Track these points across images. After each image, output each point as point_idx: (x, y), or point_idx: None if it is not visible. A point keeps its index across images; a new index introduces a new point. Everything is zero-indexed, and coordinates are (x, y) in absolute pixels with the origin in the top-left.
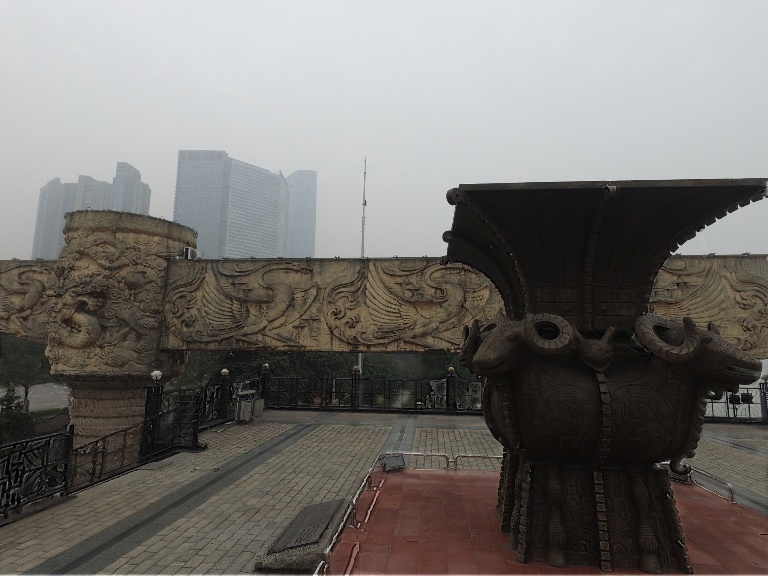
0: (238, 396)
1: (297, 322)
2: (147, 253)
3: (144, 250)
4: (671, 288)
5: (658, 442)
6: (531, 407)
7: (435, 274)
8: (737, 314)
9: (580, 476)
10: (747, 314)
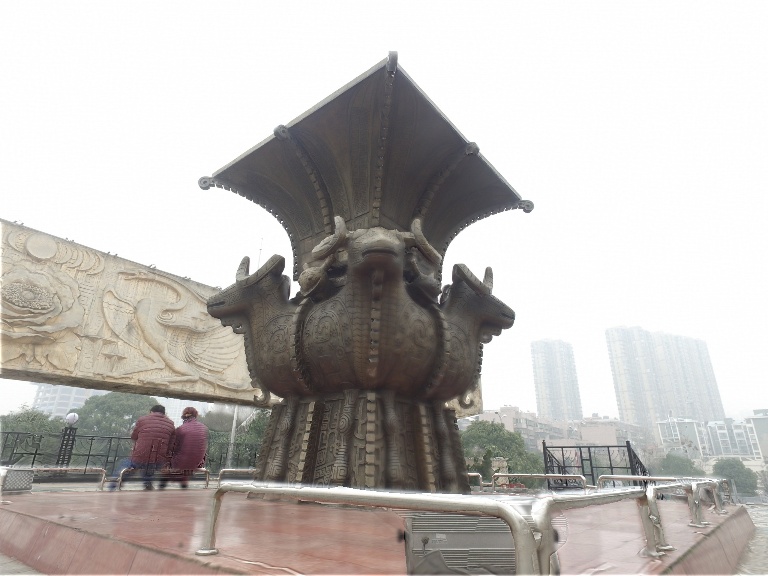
0: None
1: None
2: None
3: None
4: None
5: None
6: None
7: None
8: None
9: None
10: None
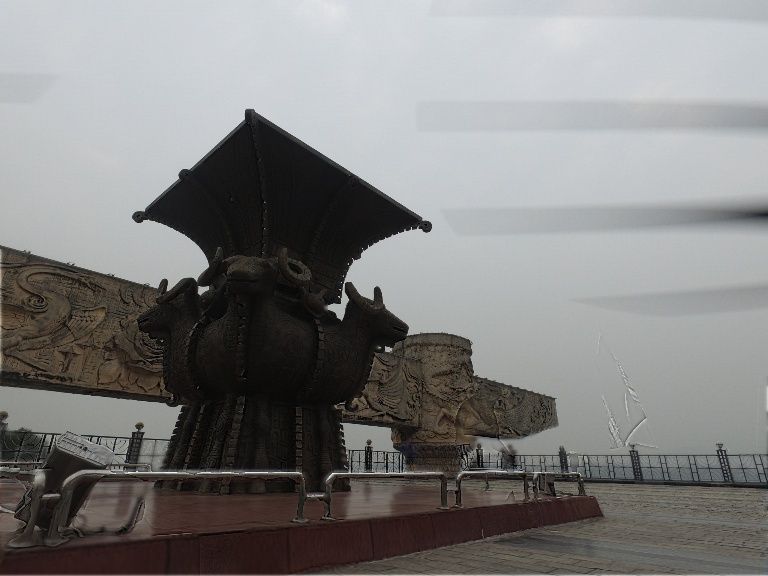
0: None
1: None
2: None
3: None
4: None
5: (346, 381)
6: (265, 334)
7: (36, 277)
8: None
9: (283, 412)
10: None
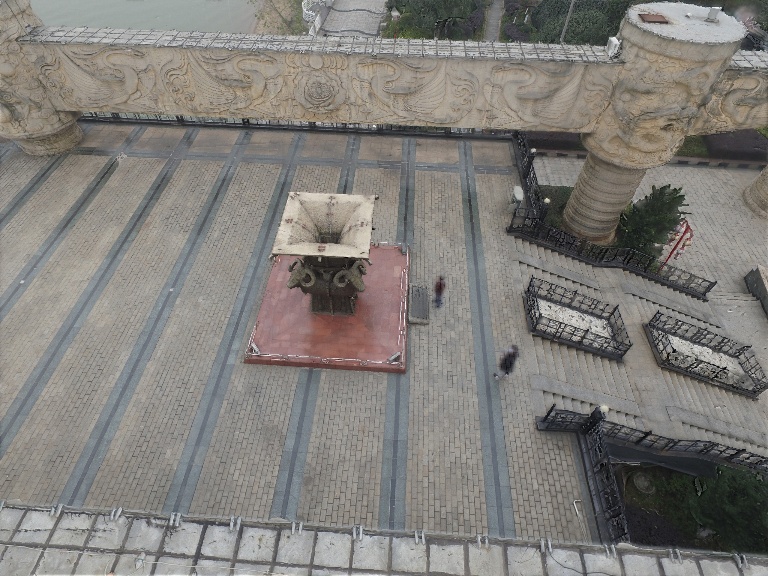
0: None
1: None
2: None
3: None
4: None
5: None
6: None
7: None
8: None
9: None
10: None
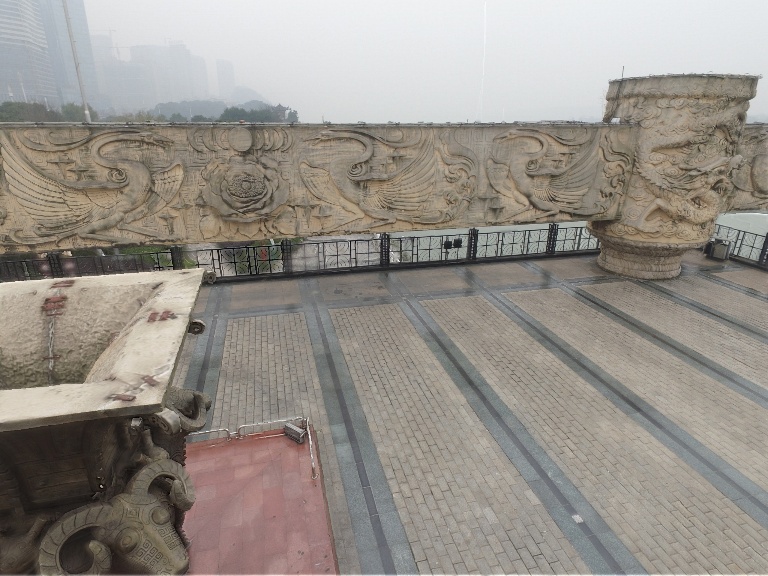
0: None
1: None
2: None
3: None
4: (386, 163)
5: None
6: None
7: (105, 148)
8: (444, 188)
9: None
10: (452, 187)
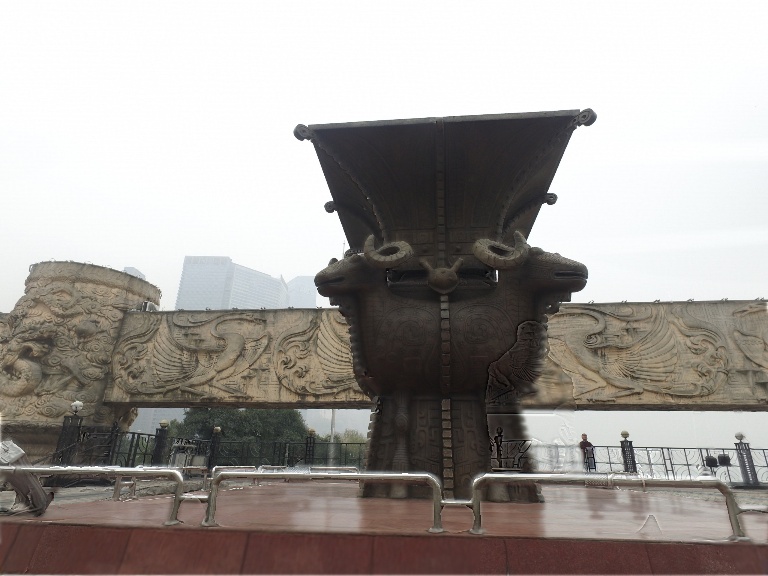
0: (174, 448)
1: (246, 372)
2: (103, 303)
3: (101, 300)
4: (621, 334)
5: None
6: (374, 328)
7: None
8: (690, 359)
9: (431, 408)
10: (700, 359)
